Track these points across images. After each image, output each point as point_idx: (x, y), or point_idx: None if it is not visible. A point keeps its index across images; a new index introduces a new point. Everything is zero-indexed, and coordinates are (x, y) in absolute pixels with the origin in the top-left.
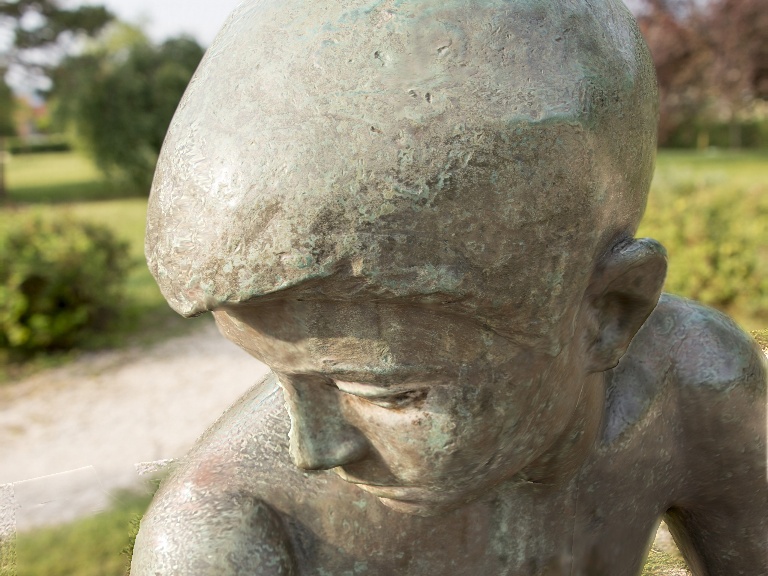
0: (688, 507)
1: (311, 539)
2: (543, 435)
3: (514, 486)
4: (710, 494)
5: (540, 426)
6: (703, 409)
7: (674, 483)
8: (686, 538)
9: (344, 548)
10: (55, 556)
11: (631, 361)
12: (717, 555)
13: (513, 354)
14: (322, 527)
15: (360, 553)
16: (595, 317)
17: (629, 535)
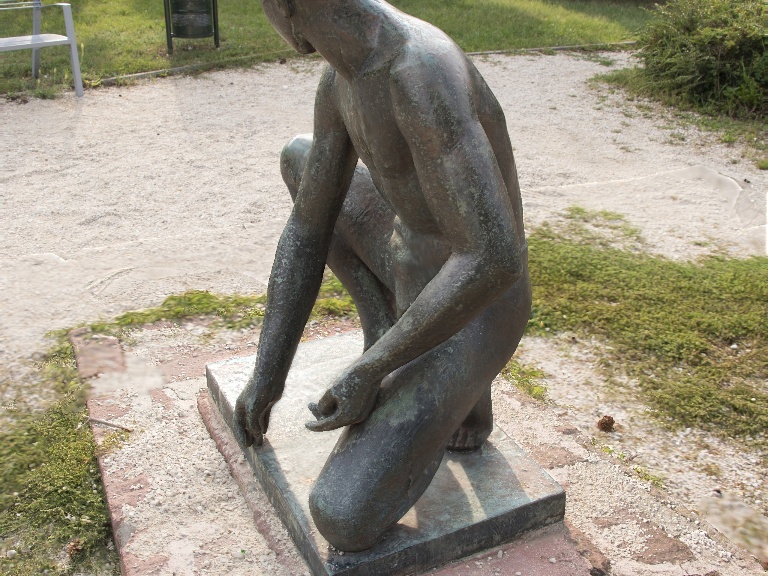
0: None
1: None
2: (281, 30)
3: None
4: None
5: None
6: None
7: None
8: None
9: None
10: None
11: None
12: None
13: None
14: None
15: None
16: None
17: (374, 119)
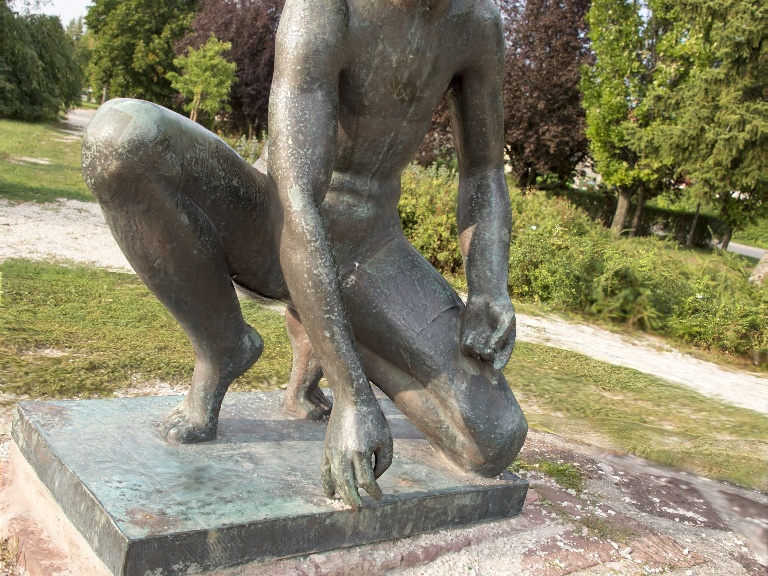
0: (465, 76)
1: (354, 8)
2: None
3: (422, 11)
4: (475, 65)
5: None
6: (480, 26)
7: (465, 52)
8: (460, 100)
9: (364, 15)
10: None
11: None
12: (471, 102)
13: None
14: (358, 5)
15: (369, 18)
16: None
17: (448, 61)
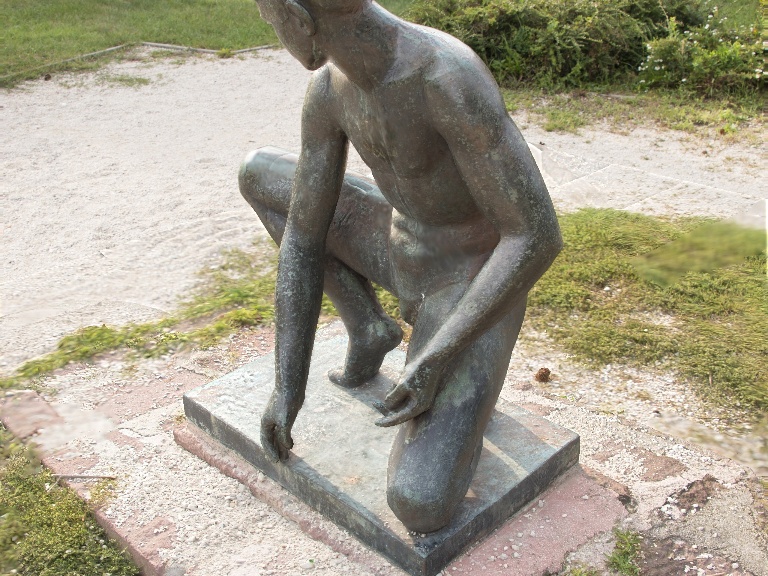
0: None
1: None
2: (299, 48)
3: None
4: None
5: (294, 44)
6: None
7: (419, 114)
8: None
9: None
10: (712, 240)
11: (406, 61)
12: None
13: (275, 20)
14: None
15: (336, 91)
16: (299, 19)
17: None
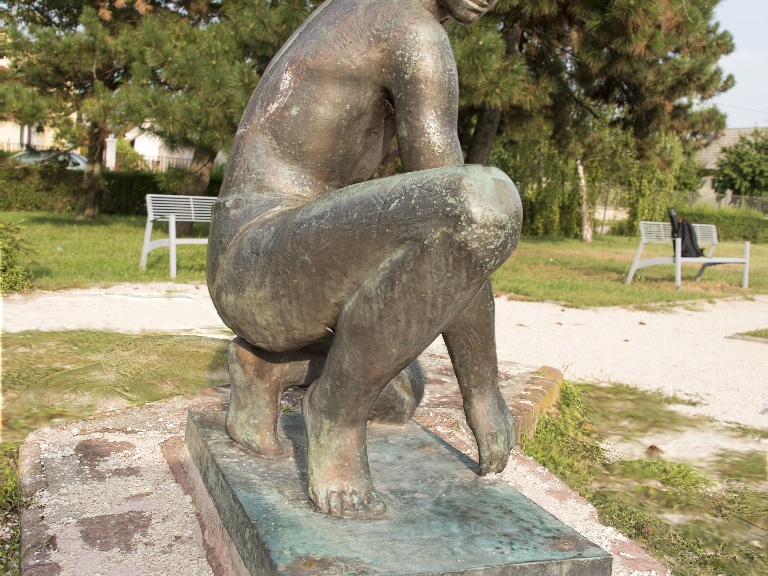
0: None
1: None
2: None
3: None
4: None
5: None
6: None
7: None
8: None
9: None
10: None
11: None
12: None
13: None
14: None
15: None
16: None
17: None
